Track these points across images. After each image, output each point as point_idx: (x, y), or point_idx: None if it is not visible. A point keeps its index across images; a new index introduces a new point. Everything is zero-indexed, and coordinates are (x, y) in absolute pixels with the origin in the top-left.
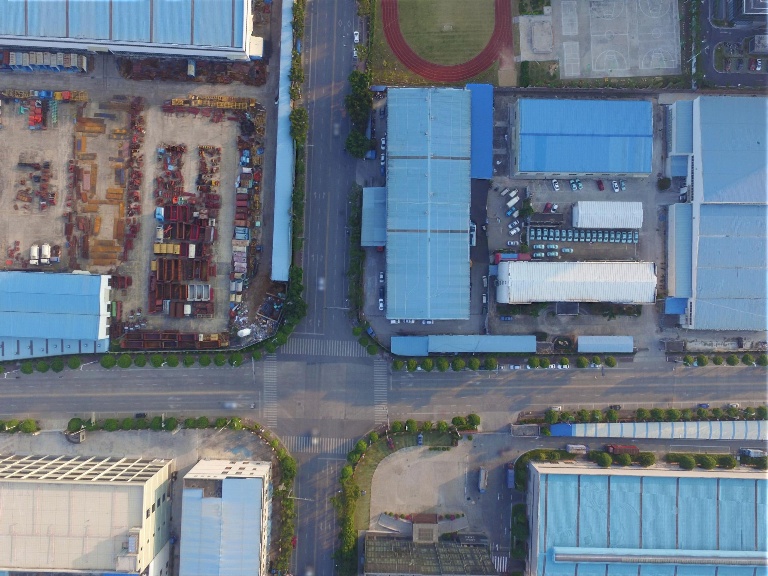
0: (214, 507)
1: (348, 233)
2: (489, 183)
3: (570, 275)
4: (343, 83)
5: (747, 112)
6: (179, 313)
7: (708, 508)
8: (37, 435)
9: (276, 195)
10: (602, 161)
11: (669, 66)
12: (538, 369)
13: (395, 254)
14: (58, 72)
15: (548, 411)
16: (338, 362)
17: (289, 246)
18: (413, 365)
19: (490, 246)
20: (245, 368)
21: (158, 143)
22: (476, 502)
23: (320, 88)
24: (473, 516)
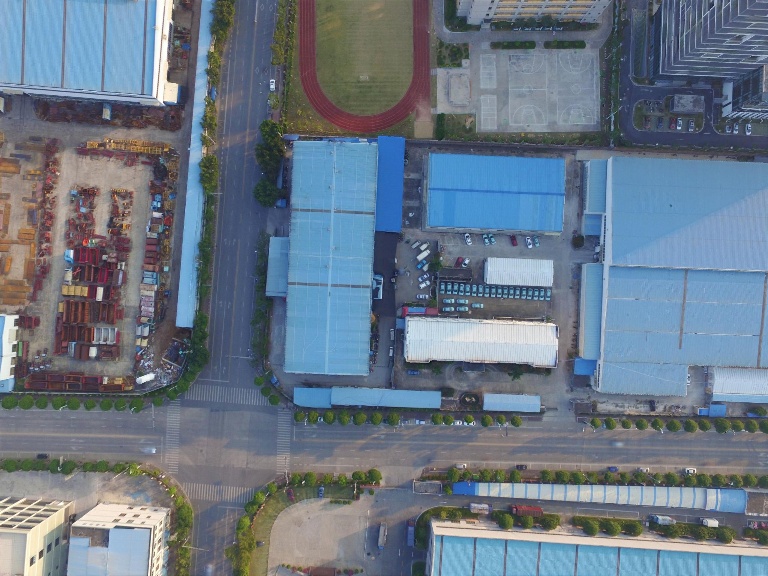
0: (100, 557)
1: (257, 281)
2: (400, 235)
3: (470, 335)
4: (258, 130)
5: (661, 174)
6: (84, 355)
7: None
8: None
9: (184, 241)
10: (512, 218)
11: (588, 122)
12: (444, 425)
13: (295, 307)
14: None
15: (450, 469)
16: (242, 410)
17: (190, 295)
18: (313, 418)
19: (399, 299)
20: (148, 412)
21: (71, 185)
22: (376, 558)
23: (235, 135)
24: (372, 572)
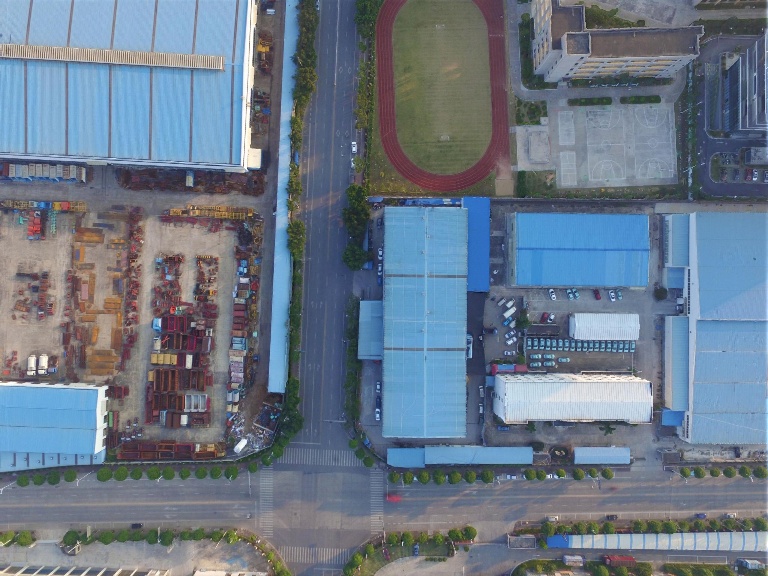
0: None
1: (345, 343)
2: (486, 293)
3: (566, 395)
4: (341, 193)
5: (743, 228)
6: (176, 424)
7: None
8: (33, 547)
9: (273, 307)
10: (599, 275)
11: (665, 176)
12: (535, 478)
13: (391, 372)
14: (57, 182)
15: (545, 524)
16: (334, 472)
17: (286, 363)
18: (409, 479)
19: (487, 355)
20: (241, 478)
21: (156, 253)
22: None
23: (318, 198)
24: None
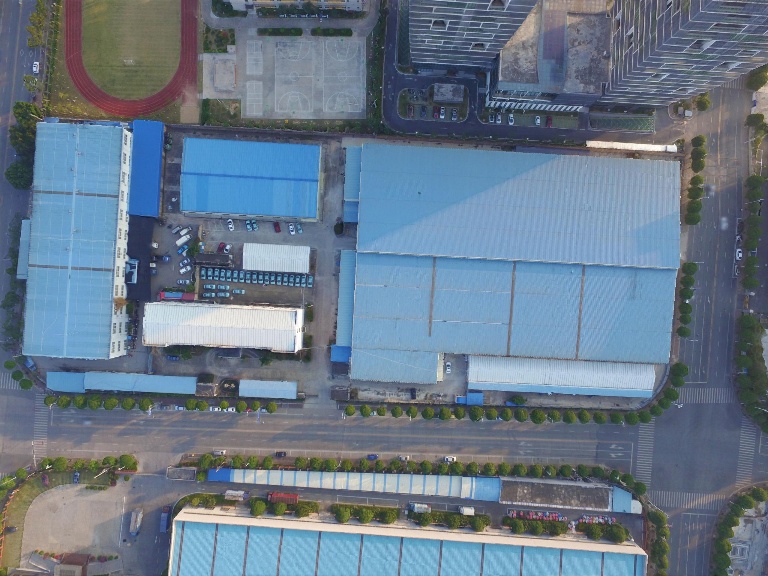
0: None
1: None
2: (160, 220)
3: (207, 319)
4: None
5: (411, 161)
6: None
7: (349, 564)
8: None
9: None
10: (266, 204)
11: (354, 110)
12: (204, 411)
13: (35, 289)
14: None
15: (202, 455)
16: None
17: None
18: (63, 402)
19: (161, 284)
20: None
21: None
22: (132, 544)
23: None
24: (128, 559)
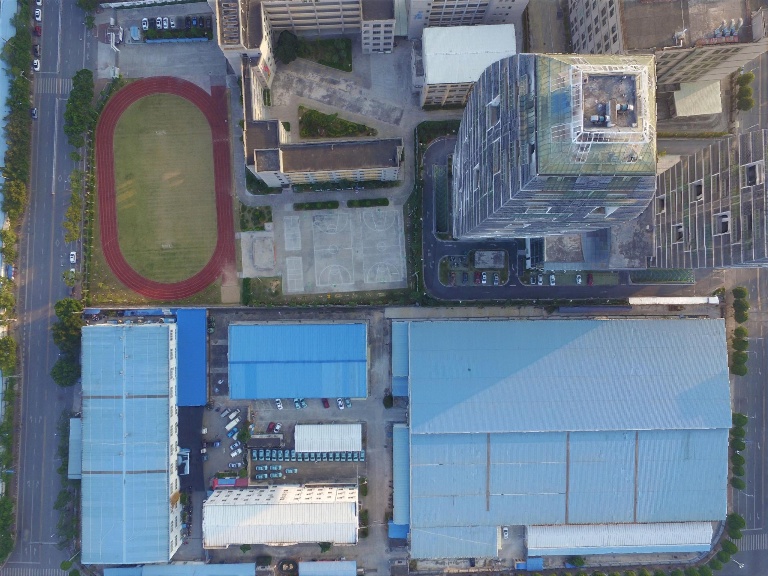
0: None
1: None
2: (208, 405)
3: (267, 518)
4: None
5: (459, 337)
6: None
7: None
8: None
9: None
10: (315, 387)
11: (395, 279)
12: None
13: (90, 497)
14: None
15: None
16: None
17: None
18: None
19: (212, 468)
20: None
21: None
22: None
23: (37, 309)
24: None
